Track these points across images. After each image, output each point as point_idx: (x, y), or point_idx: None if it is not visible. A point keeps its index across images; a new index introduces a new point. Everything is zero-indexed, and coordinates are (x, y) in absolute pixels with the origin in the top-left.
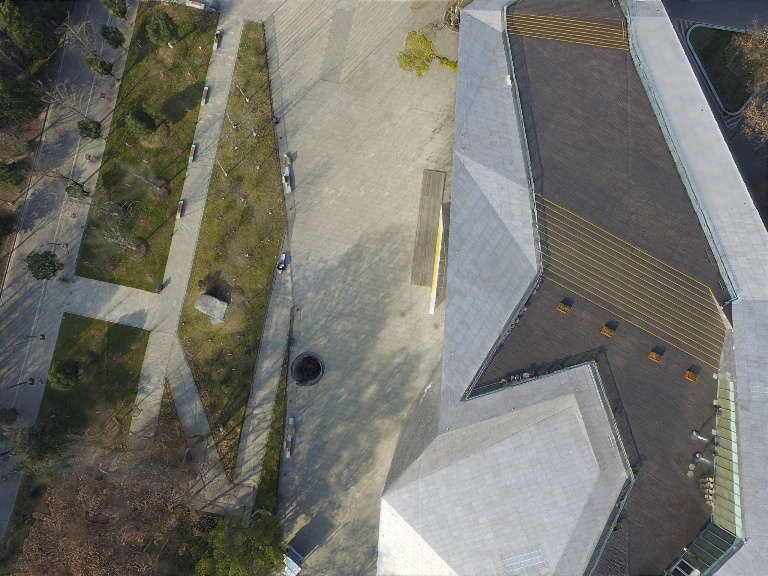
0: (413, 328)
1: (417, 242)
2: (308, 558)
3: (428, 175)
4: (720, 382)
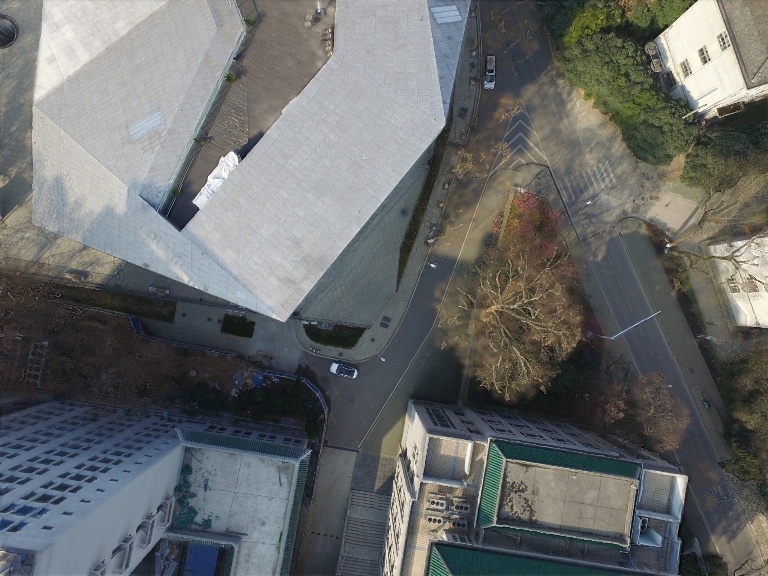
0: None
1: None
2: (8, 218)
3: None
4: None
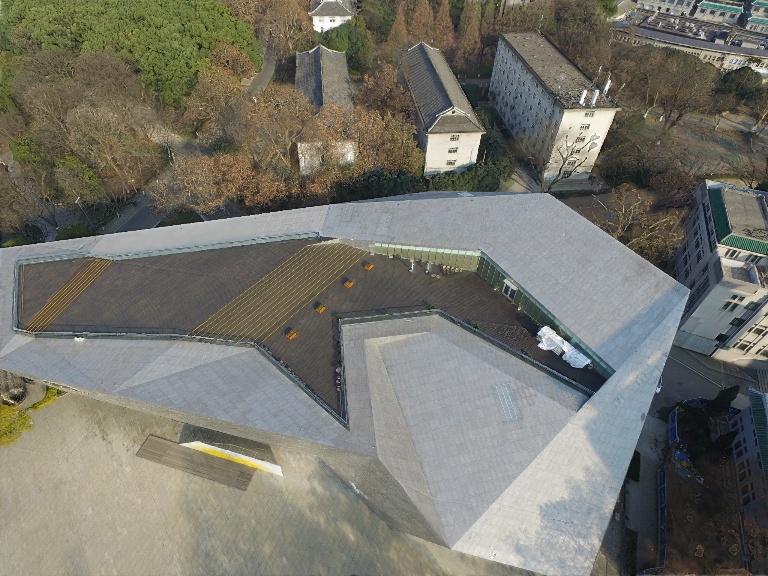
0: (292, 497)
1: (205, 476)
2: None
3: (143, 452)
4: (377, 252)
